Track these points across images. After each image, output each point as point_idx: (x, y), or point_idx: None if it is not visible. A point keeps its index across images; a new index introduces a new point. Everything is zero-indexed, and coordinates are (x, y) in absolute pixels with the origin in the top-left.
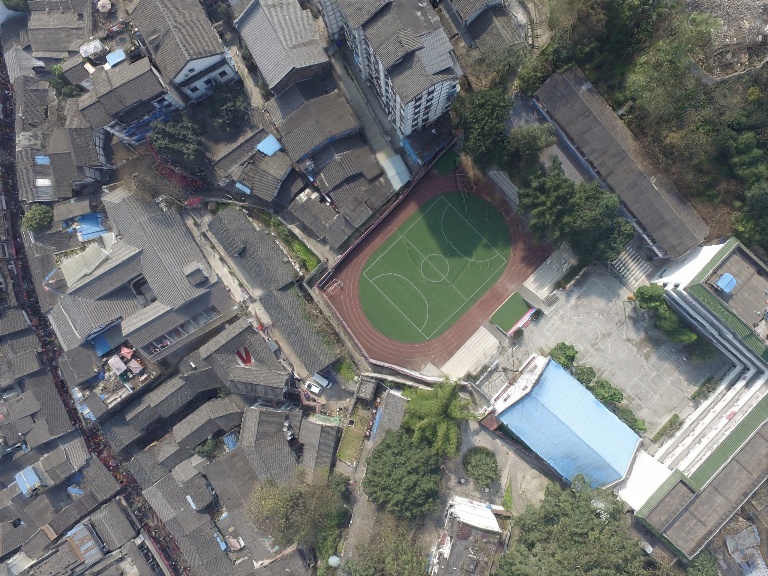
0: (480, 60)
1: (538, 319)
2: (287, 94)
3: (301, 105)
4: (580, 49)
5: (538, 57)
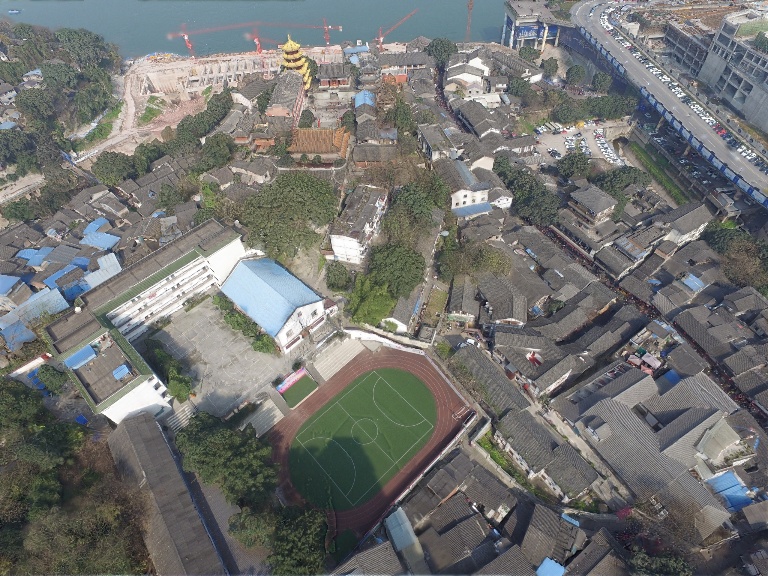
0: None
1: None
2: None
3: None
4: None
5: None
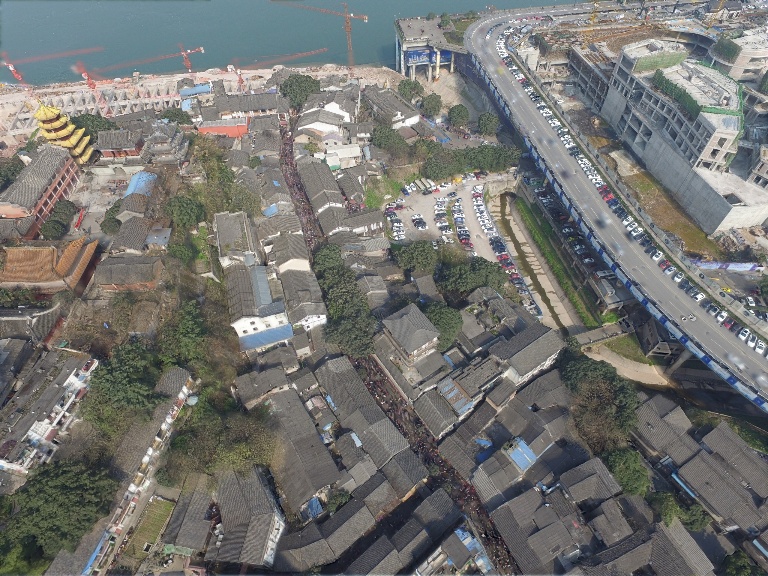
0: None
1: None
2: None
3: None
4: None
5: None
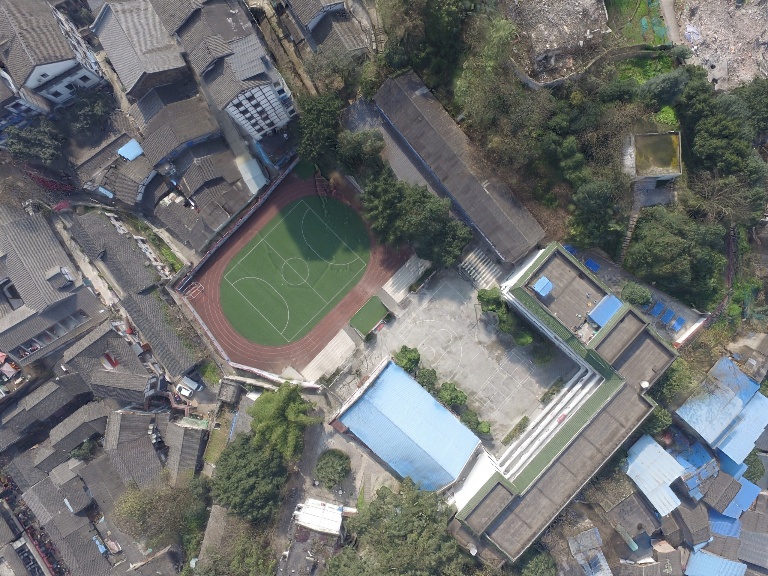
0: (325, 65)
1: (391, 322)
2: (148, 99)
3: (160, 110)
4: (416, 54)
5: (375, 62)
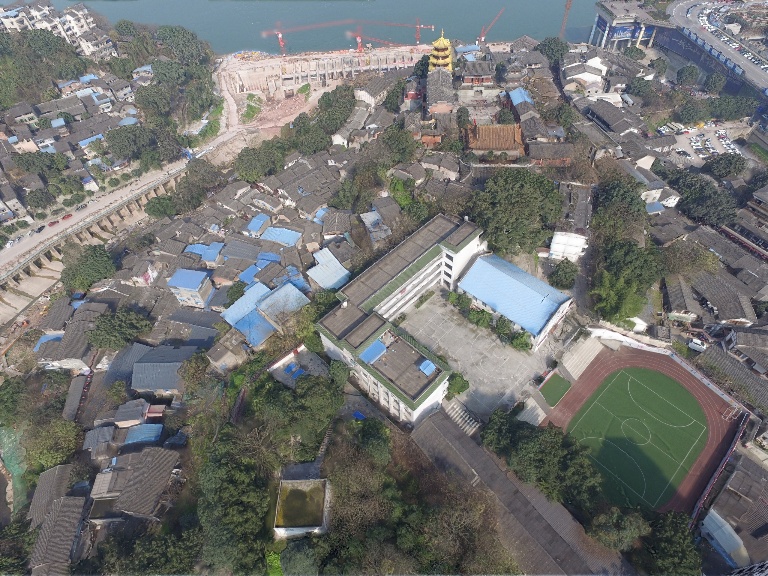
0: None
1: None
2: None
3: None
4: None
5: None
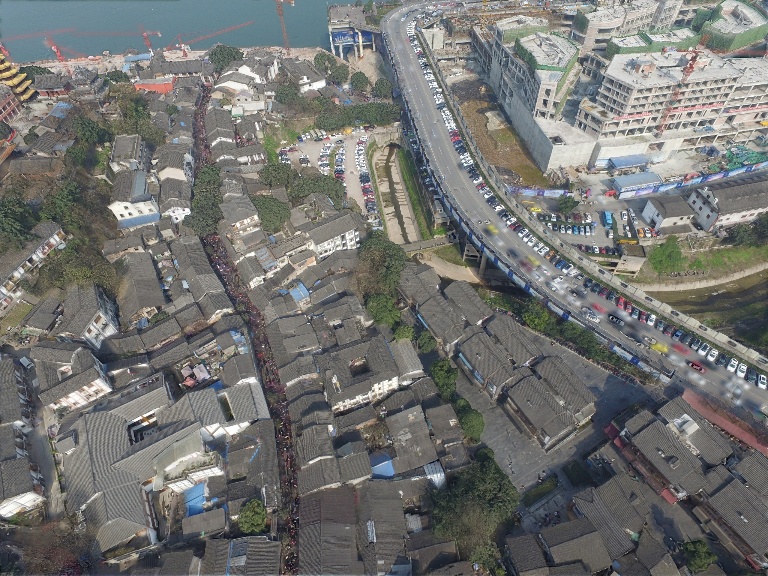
0: None
1: None
2: None
3: None
4: None
5: None
